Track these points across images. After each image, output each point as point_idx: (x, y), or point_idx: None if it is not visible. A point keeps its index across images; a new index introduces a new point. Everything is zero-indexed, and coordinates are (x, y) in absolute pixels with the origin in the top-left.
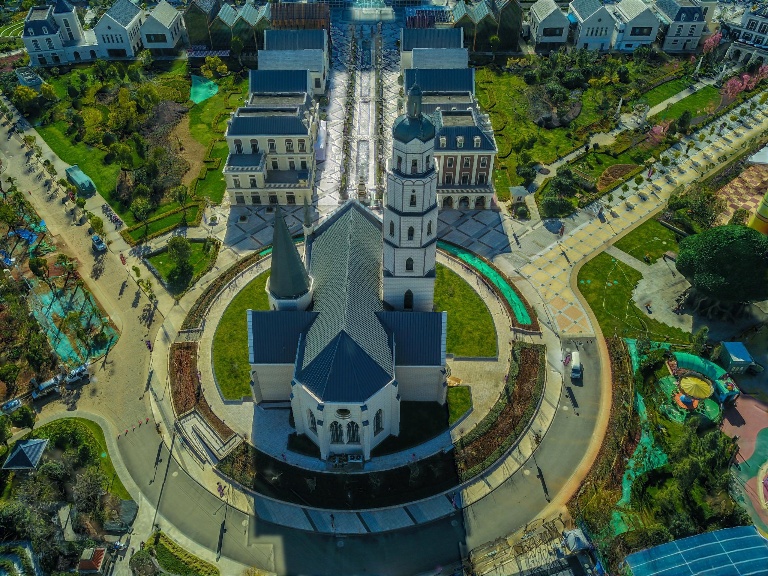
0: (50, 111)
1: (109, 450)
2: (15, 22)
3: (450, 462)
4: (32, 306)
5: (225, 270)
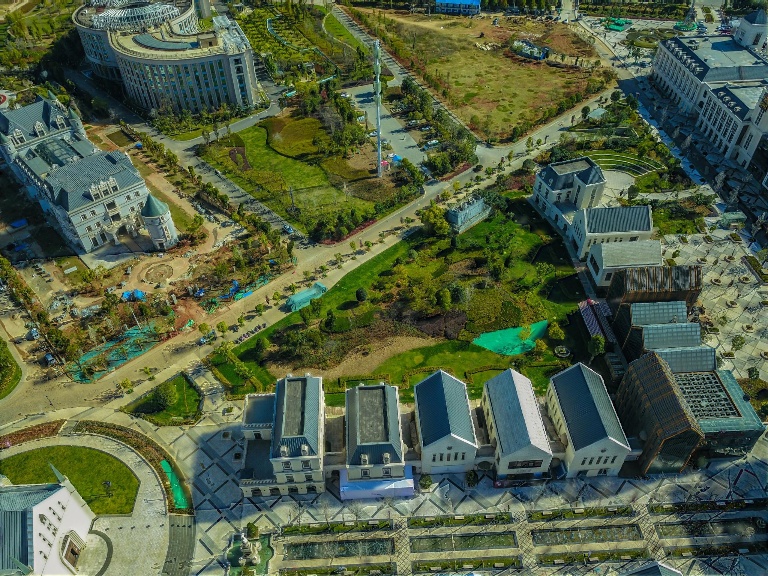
0: (431, 239)
1: None
2: (626, 153)
3: None
4: (108, 323)
5: (149, 436)
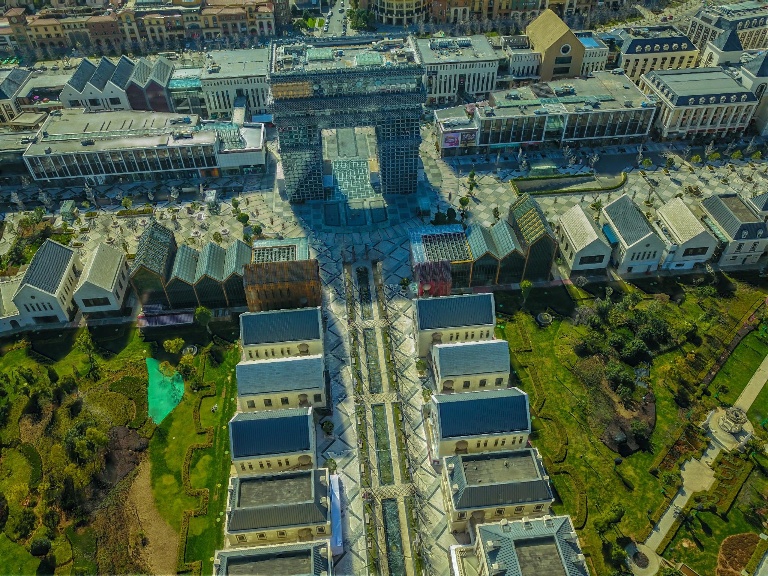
0: None
1: None
2: None
3: None
4: None
5: None
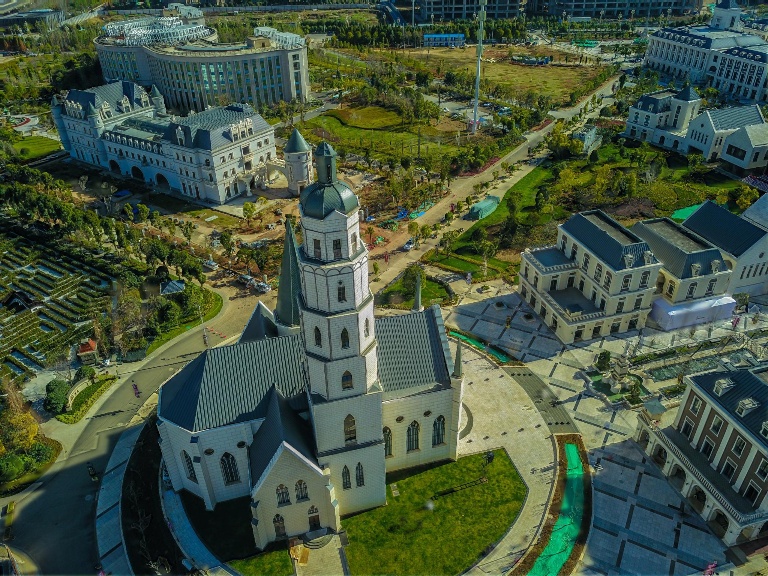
0: (565, 162)
1: (193, 328)
2: None
3: (173, 574)
4: None
5: None
